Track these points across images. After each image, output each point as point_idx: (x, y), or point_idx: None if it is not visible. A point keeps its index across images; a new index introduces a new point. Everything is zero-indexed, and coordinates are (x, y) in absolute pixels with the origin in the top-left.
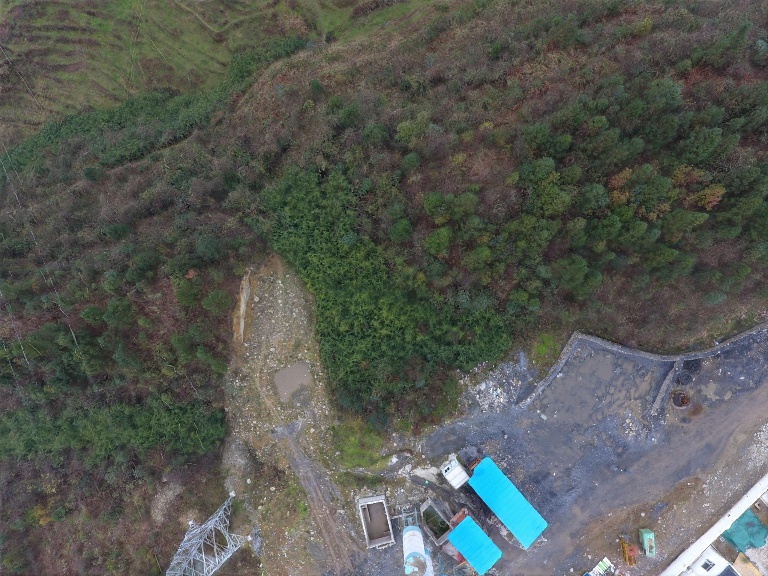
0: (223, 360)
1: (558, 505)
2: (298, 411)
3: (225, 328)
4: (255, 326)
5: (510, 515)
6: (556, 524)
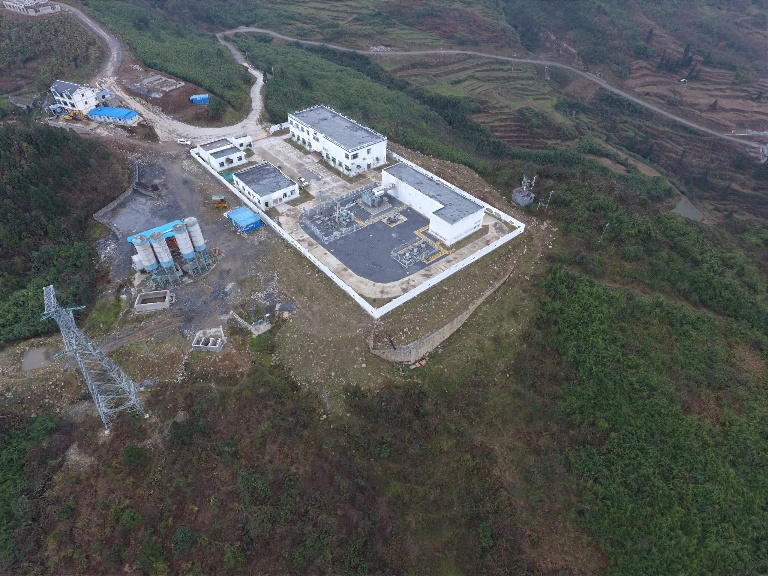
0: None
1: None
2: None
3: None
4: None
5: None
6: None
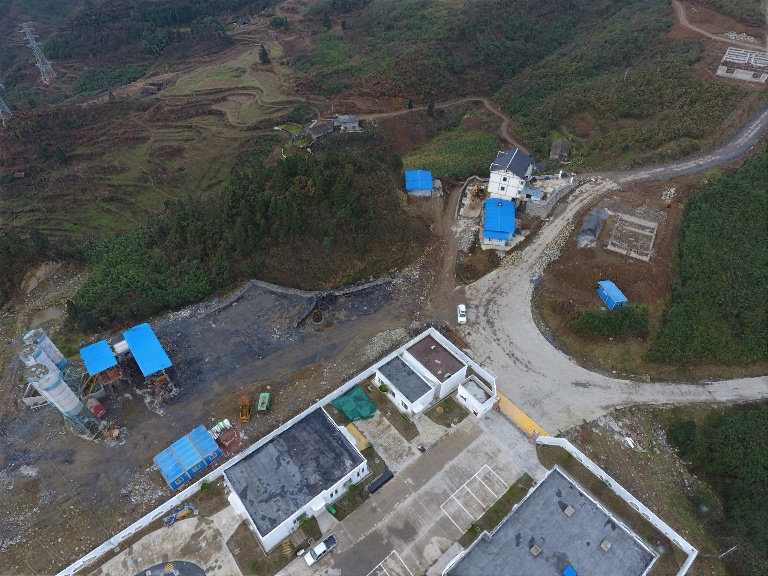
0: (4, 293)
1: (201, 380)
2: None
3: (18, 275)
4: (43, 288)
5: (144, 355)
6: (195, 395)
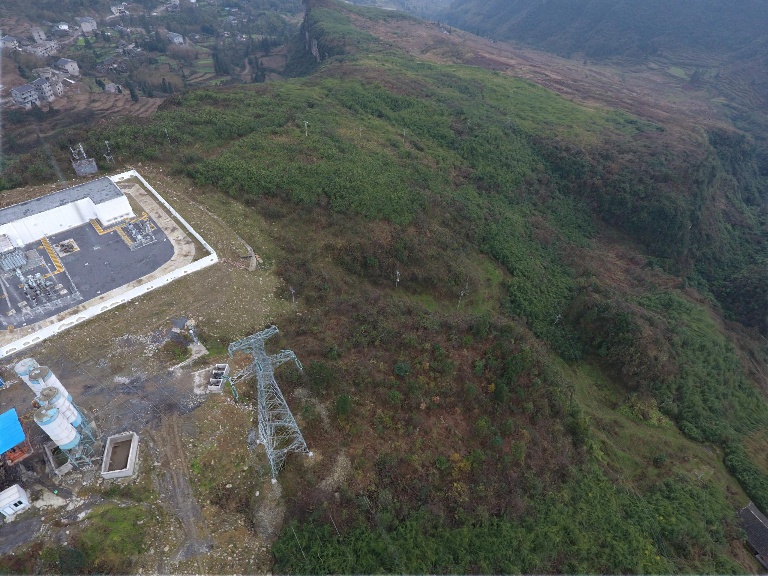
0: None
1: None
2: (176, 573)
3: None
4: None
5: None
6: None
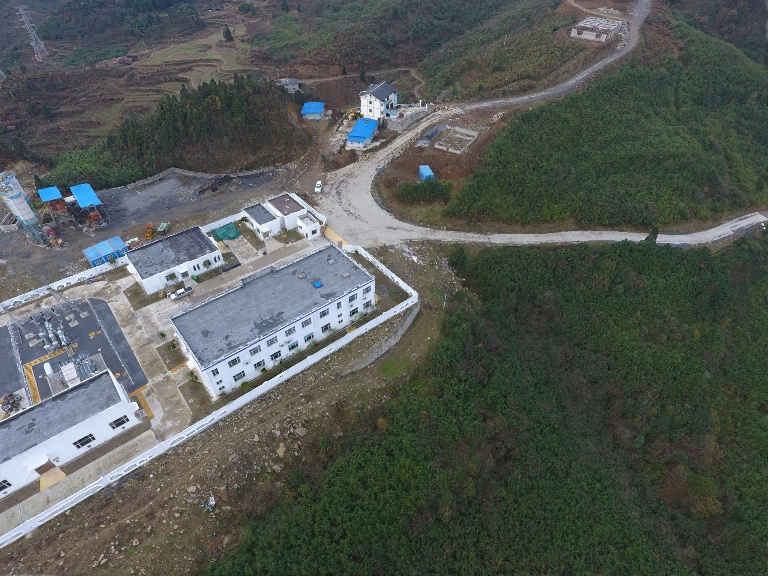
0: None
1: (124, 220)
2: None
3: (1, 165)
4: None
5: (83, 198)
6: (118, 227)
